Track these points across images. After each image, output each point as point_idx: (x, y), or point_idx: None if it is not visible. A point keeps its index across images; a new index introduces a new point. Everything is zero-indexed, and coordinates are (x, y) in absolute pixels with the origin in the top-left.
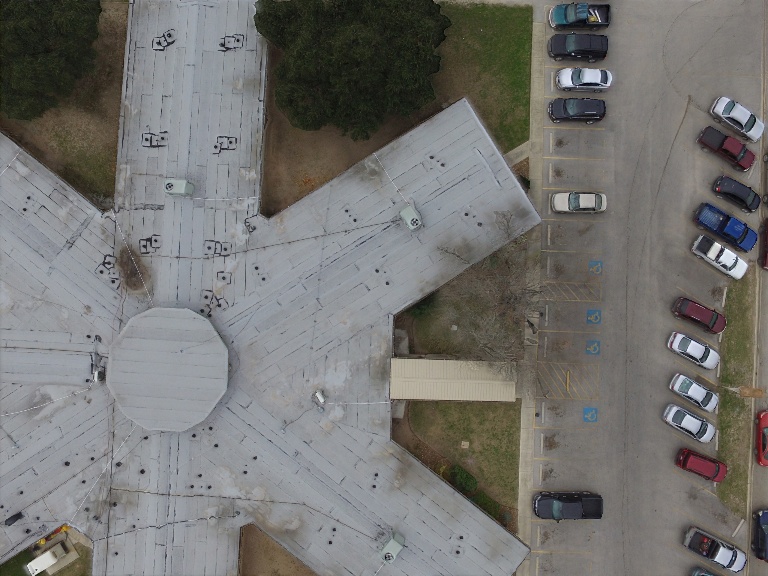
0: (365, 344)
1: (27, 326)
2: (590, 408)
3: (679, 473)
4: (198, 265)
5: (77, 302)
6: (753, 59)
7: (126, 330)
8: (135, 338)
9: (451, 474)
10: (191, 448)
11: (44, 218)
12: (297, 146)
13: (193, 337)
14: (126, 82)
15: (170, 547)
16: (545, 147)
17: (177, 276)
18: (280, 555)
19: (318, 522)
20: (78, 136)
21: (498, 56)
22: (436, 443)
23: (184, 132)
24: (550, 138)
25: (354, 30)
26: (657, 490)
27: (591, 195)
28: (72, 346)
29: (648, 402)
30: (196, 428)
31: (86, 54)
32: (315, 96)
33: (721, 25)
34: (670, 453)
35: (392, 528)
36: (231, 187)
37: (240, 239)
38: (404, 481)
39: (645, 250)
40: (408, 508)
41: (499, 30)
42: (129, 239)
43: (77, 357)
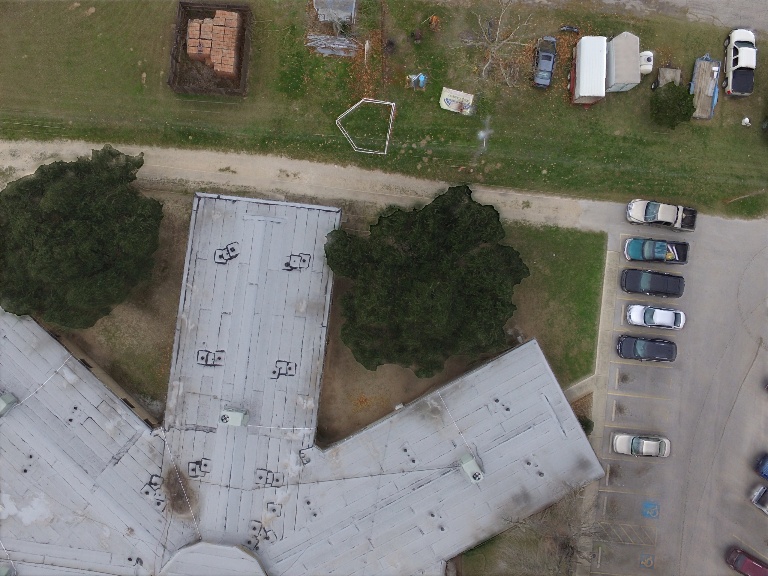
0: None
1: (66, 542)
2: None
3: None
4: (248, 495)
5: (120, 523)
6: None
7: (171, 565)
8: (180, 574)
9: None
10: None
11: (90, 430)
12: (355, 362)
13: None
14: (184, 294)
15: None
16: (610, 383)
17: (226, 505)
18: None
19: None
20: (128, 332)
21: (569, 284)
22: None
23: (242, 354)
24: (616, 374)
25: (433, 290)
26: None
27: (655, 443)
28: (112, 568)
29: None
30: None
31: (145, 264)
32: (383, 337)
33: None
34: None
35: None
36: (287, 415)
37: (293, 470)
38: None
39: (704, 495)
40: None
41: (572, 256)
42: (178, 461)
43: None
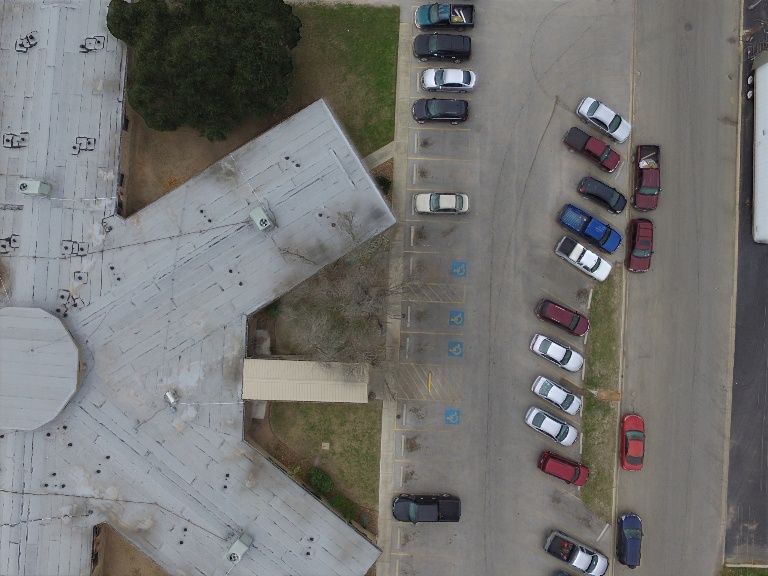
0: (218, 344)
1: None
2: (452, 410)
3: (542, 476)
4: (55, 265)
5: None
6: (622, 59)
7: None
8: None
9: (308, 475)
10: (46, 447)
11: None
12: (163, 147)
13: (44, 336)
14: None
15: (24, 545)
16: (410, 148)
17: (34, 276)
18: (141, 555)
19: (170, 522)
20: None
21: (364, 57)
22: (296, 444)
23: (43, 133)
24: (415, 139)
25: (195, 31)
26: (520, 493)
27: (451, 196)
28: None
29: (511, 404)
30: (51, 427)
31: None
32: (167, 97)
33: (590, 25)
34: (533, 456)
35: (242, 529)
36: (89, 187)
37: (97, 239)
38: (256, 482)
39: (510, 251)
40: (259, 509)
41: (366, 31)
42: None
43: None
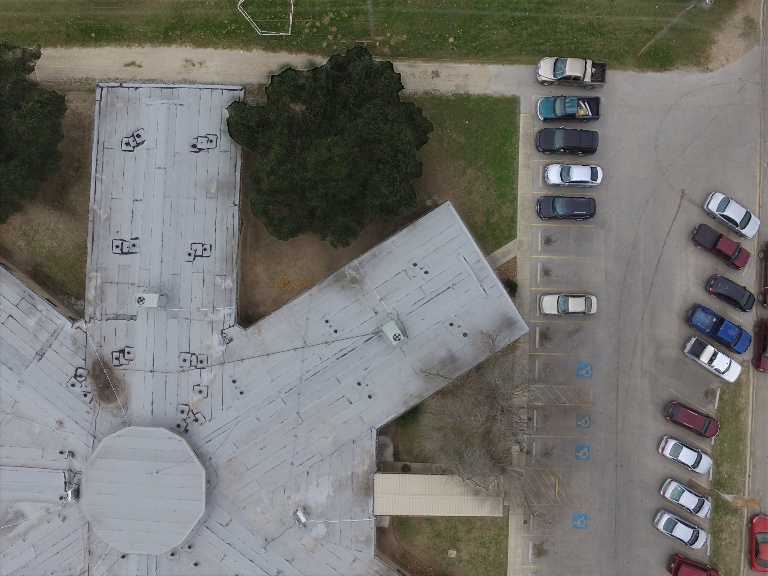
0: (347, 459)
1: None
2: (579, 514)
3: None
4: (173, 378)
5: (48, 417)
6: (749, 150)
7: (99, 450)
8: (108, 459)
9: None
10: (169, 567)
11: (12, 329)
12: (276, 246)
13: (169, 458)
14: (94, 185)
15: None
16: (533, 245)
17: (151, 390)
18: None
19: None
20: (47, 235)
21: (484, 150)
22: (422, 552)
23: (156, 239)
24: (538, 236)
25: (331, 144)
26: None
27: (581, 298)
28: (44, 463)
29: (639, 507)
30: None
31: (51, 157)
32: (292, 205)
33: (716, 114)
34: (661, 558)
35: None
36: (206, 296)
37: (216, 351)
38: None
39: (636, 351)
40: None
41: (485, 122)
42: (101, 351)
43: (49, 474)
